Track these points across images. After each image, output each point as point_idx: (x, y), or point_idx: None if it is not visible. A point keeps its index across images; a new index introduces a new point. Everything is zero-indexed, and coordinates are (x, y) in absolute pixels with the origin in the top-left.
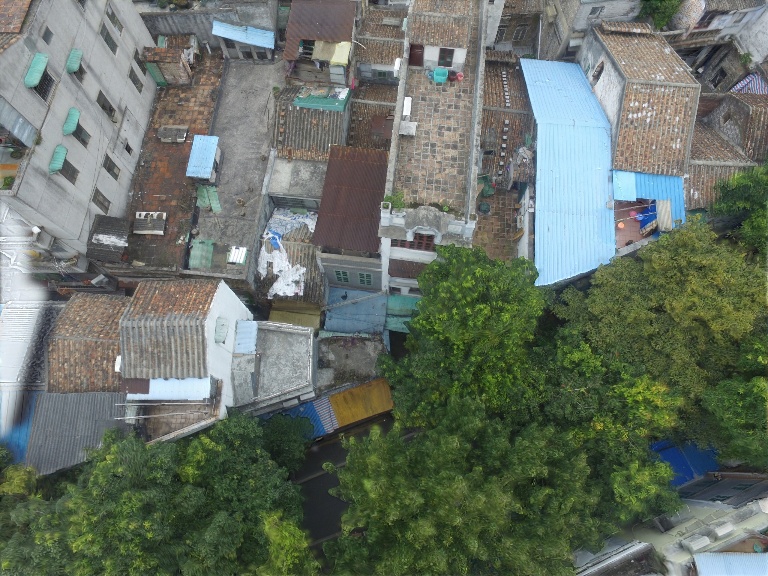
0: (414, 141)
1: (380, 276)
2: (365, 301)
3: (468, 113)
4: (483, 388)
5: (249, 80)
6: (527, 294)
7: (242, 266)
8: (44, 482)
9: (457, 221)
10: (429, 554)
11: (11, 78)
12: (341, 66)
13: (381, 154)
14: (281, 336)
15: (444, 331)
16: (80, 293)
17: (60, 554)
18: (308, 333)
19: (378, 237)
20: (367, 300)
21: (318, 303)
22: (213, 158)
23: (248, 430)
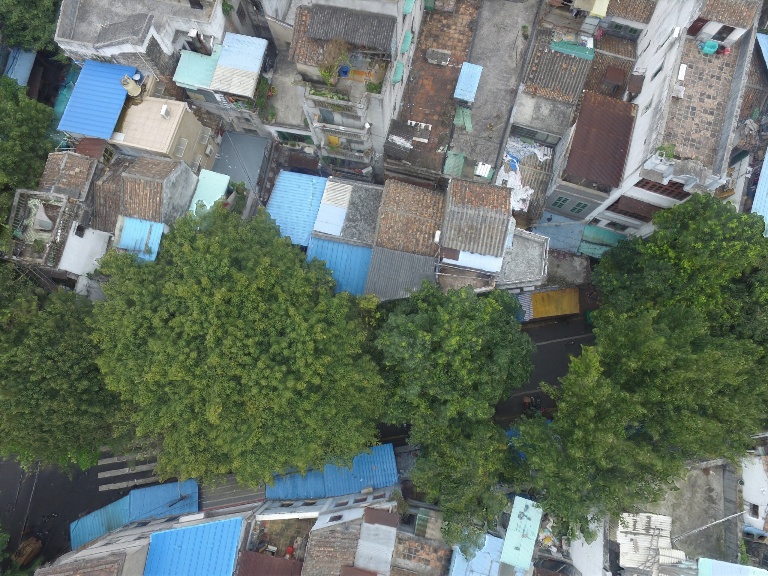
0: (678, 103)
1: (595, 207)
2: (566, 226)
3: (727, 85)
4: (690, 305)
5: (501, 15)
6: (765, 241)
7: (486, 179)
8: (377, 306)
9: (713, 176)
10: (674, 393)
11: (401, 7)
12: (598, 18)
13: (627, 106)
14: (520, 240)
15: (675, 258)
16: (392, 179)
17: (430, 346)
18: (543, 241)
19: (619, 176)
20: (568, 225)
21: (532, 220)
22: (477, 85)
23: (512, 300)
